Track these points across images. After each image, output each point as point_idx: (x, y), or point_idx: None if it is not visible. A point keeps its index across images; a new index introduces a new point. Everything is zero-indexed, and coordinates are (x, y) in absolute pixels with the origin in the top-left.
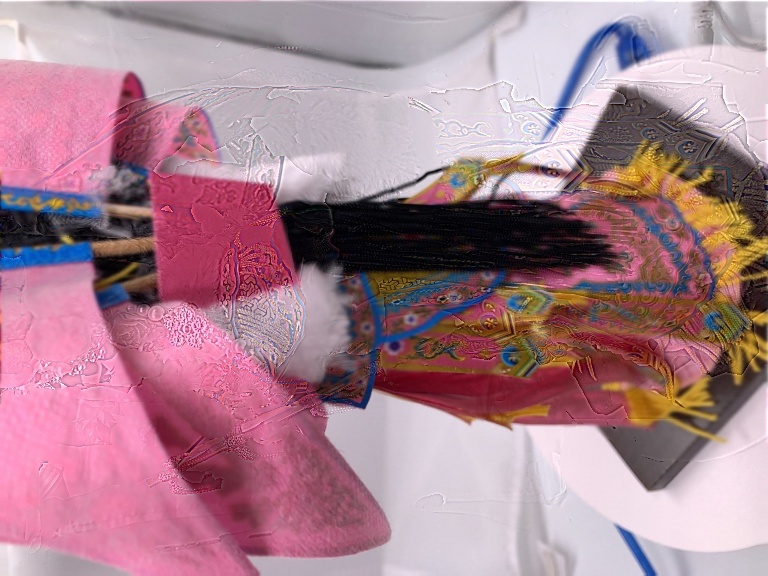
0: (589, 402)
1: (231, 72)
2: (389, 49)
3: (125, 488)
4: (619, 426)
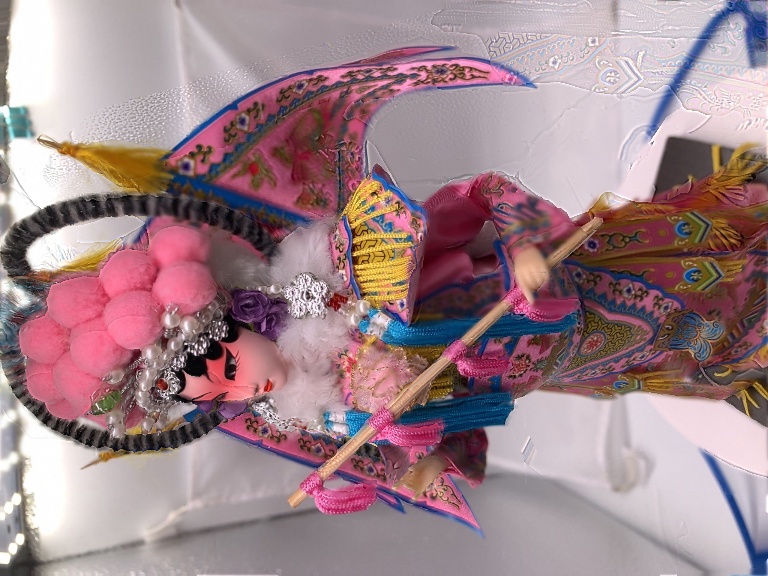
0: None
1: None
2: None
3: None
4: None
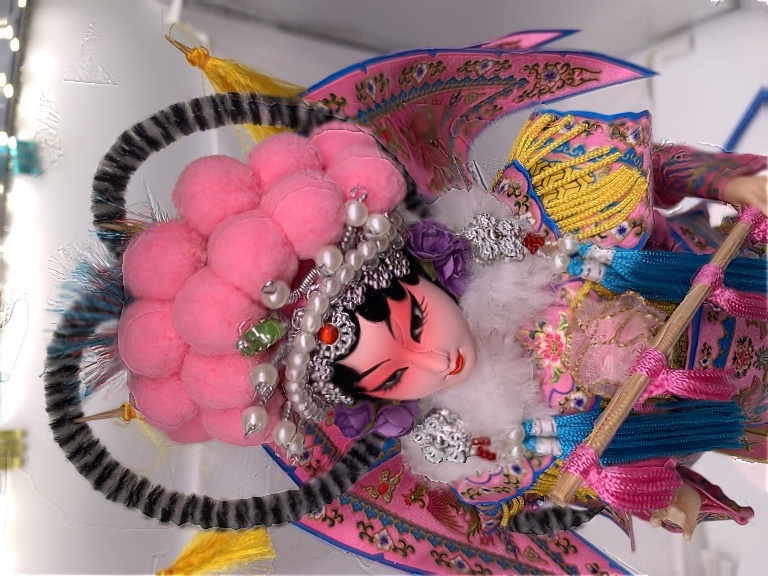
0: None
1: None
2: None
3: None
4: None
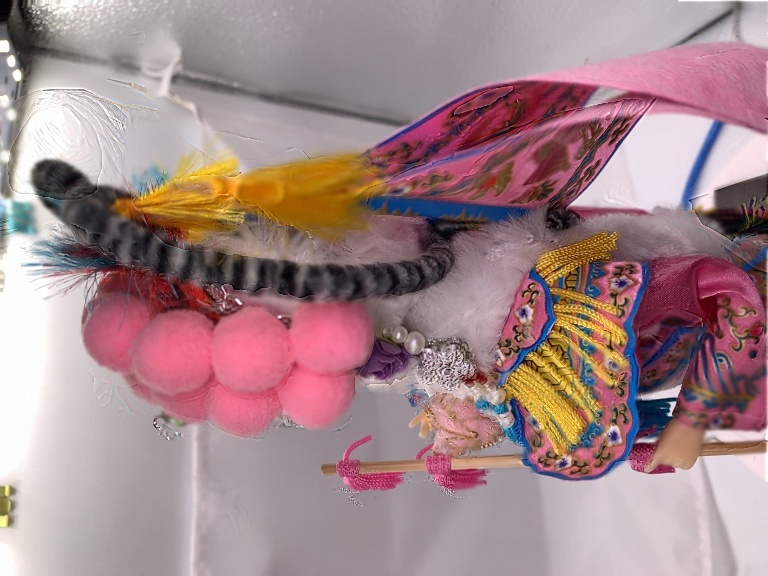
0: None
1: None
2: None
3: None
4: None
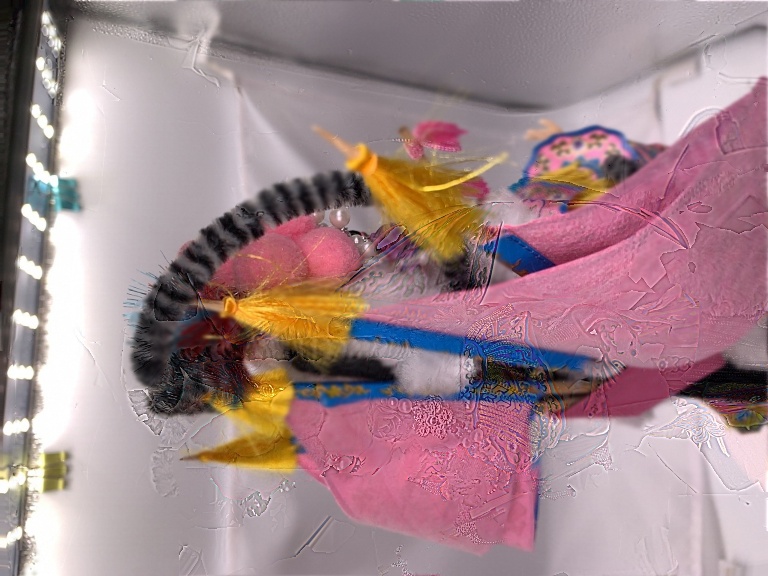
0: (721, 478)
1: (346, 162)
2: (494, 140)
3: (260, 571)
4: (754, 502)
